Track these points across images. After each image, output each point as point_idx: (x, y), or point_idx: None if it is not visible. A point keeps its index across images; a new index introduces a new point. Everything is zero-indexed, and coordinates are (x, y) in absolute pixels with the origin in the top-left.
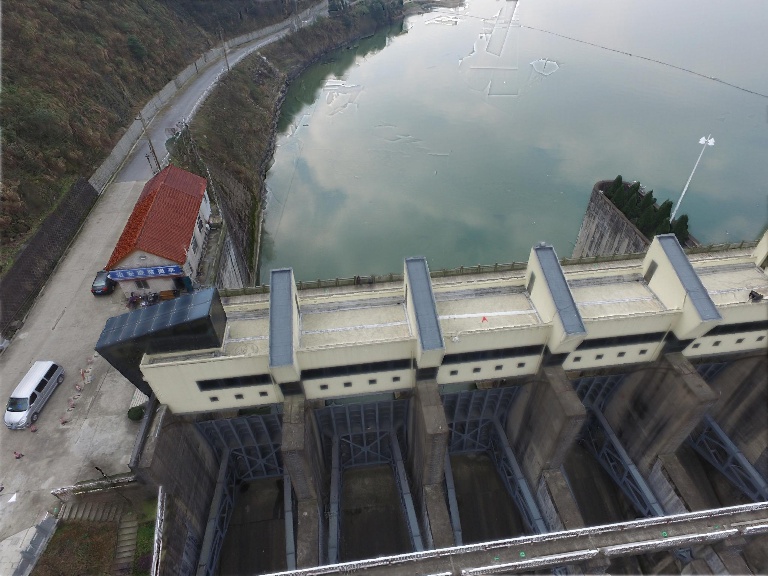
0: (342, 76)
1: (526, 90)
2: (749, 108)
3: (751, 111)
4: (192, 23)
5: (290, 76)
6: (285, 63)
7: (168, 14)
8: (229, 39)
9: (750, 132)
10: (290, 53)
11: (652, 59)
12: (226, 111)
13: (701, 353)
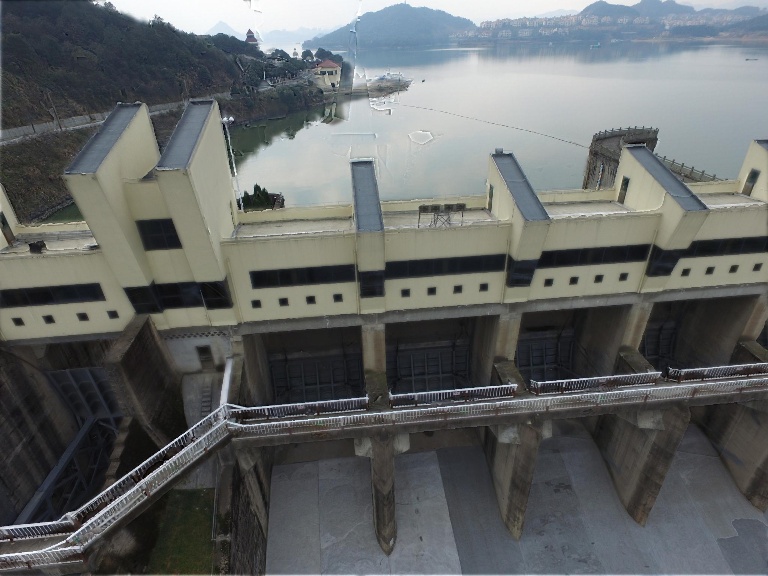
0: (250, 152)
1: (412, 160)
2: (567, 158)
3: (569, 161)
4: (60, 95)
5: (162, 144)
6: (159, 133)
7: (23, 84)
8: (105, 111)
9: (567, 180)
10: (171, 125)
11: (523, 129)
12: (18, 159)
13: (43, 335)
